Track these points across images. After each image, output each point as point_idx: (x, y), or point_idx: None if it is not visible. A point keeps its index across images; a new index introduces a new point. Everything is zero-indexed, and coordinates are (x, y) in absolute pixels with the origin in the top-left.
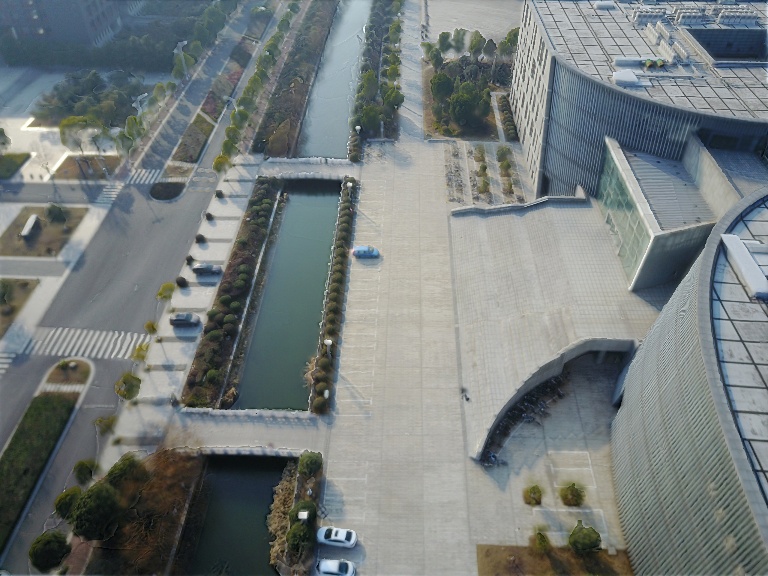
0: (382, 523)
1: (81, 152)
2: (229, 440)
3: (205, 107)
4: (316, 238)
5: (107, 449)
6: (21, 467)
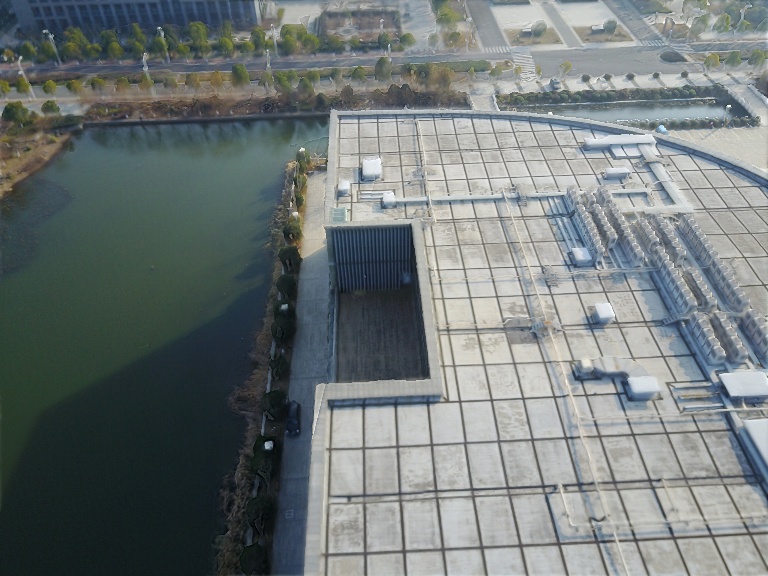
0: None
1: (686, 22)
2: None
3: None
4: None
5: (464, 83)
6: (448, 67)
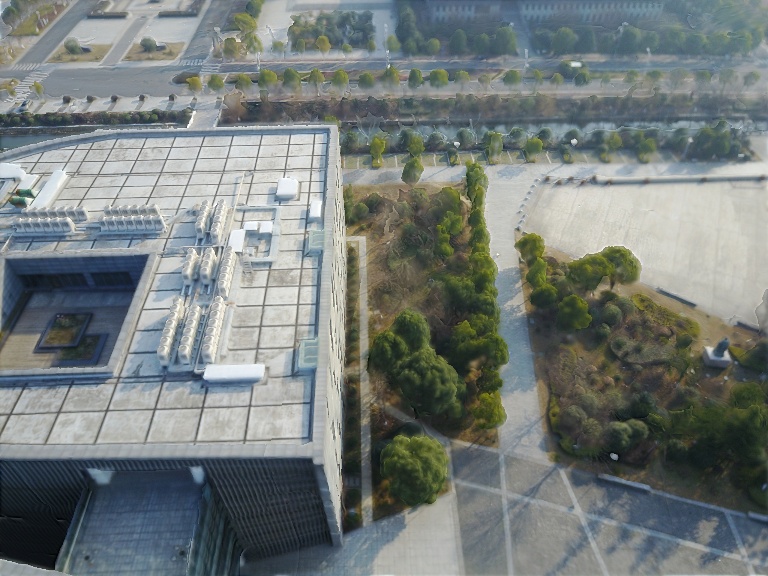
0: None
1: None
2: None
3: (325, 73)
4: None
5: None
6: None
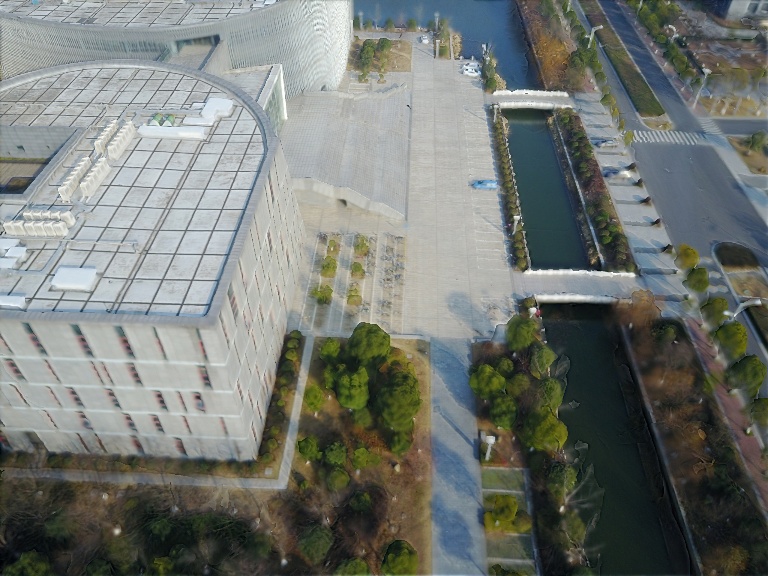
0: (453, 77)
1: None
2: (538, 98)
3: None
4: (540, 231)
5: None
6: None
